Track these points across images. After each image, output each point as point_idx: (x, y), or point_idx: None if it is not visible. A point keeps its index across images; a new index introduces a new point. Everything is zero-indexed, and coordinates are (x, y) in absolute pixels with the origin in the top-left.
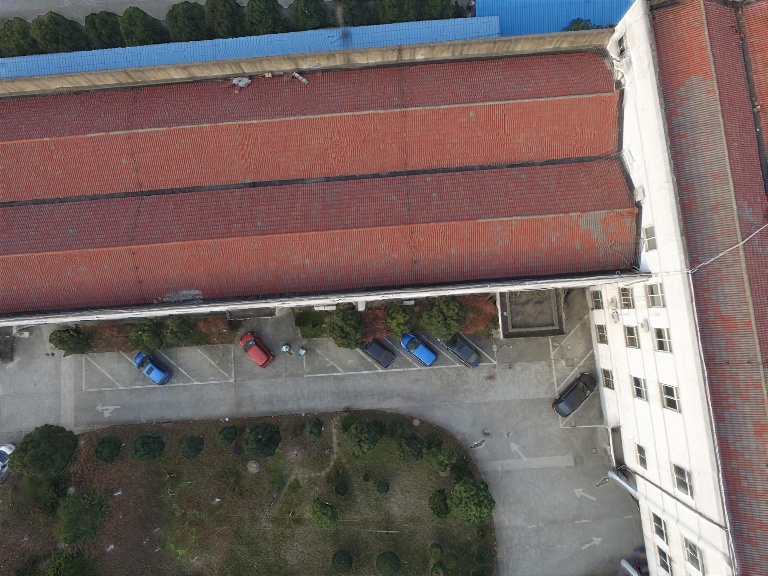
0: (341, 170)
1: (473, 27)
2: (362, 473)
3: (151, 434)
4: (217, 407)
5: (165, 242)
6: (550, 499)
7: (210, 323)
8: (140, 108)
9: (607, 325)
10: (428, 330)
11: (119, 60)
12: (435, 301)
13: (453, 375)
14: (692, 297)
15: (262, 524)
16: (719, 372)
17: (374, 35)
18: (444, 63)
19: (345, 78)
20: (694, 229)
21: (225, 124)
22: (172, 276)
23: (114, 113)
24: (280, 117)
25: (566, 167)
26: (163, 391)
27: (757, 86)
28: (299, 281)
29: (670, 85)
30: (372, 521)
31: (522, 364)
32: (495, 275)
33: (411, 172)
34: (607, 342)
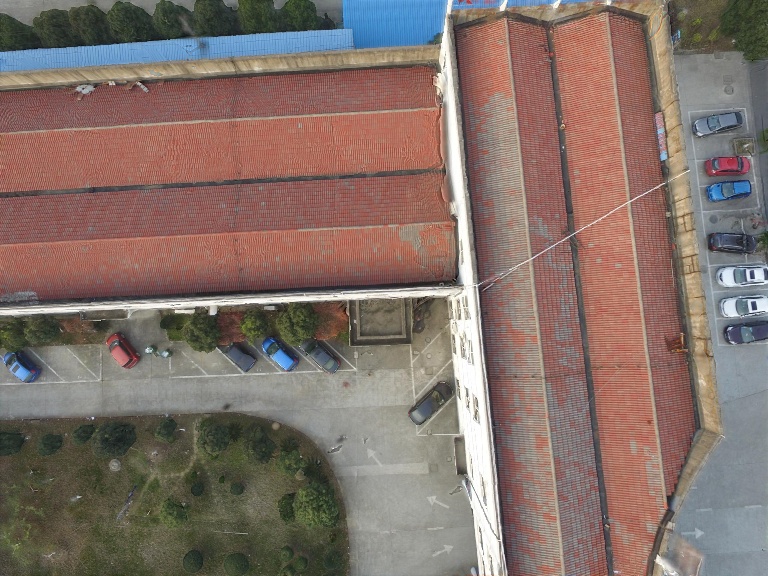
0: (187, 177)
1: (327, 39)
2: (220, 475)
3: (18, 431)
4: (83, 406)
5: None
6: (404, 506)
7: (74, 323)
8: None
9: (455, 335)
10: None
11: None
12: (288, 307)
13: (314, 380)
14: (478, 311)
15: (121, 522)
16: (508, 385)
17: (231, 45)
18: (282, 75)
19: (185, 88)
20: (492, 244)
21: (61, 130)
22: (7, 277)
23: None
24: None
25: (395, 179)
26: (32, 389)
27: (563, 105)
28: (130, 285)
29: (476, 102)
30: (227, 522)
31: (382, 371)
32: (321, 284)
33: (245, 181)
34: (455, 352)
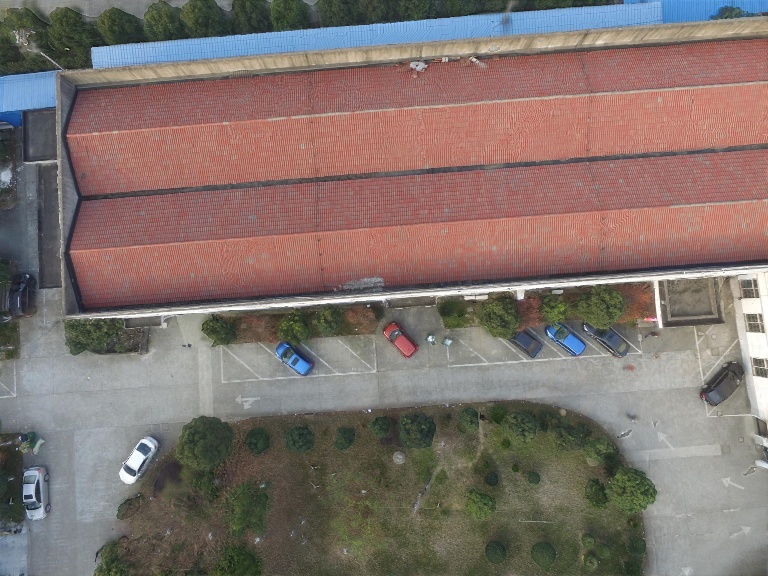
0: None
1: (635, 13)
2: (510, 464)
3: (293, 426)
4: (360, 398)
5: (352, 228)
6: (698, 488)
7: (358, 313)
8: (323, 92)
9: (764, 314)
10: (574, 320)
11: (274, 45)
12: (591, 290)
13: (599, 365)
14: None
15: (409, 516)
16: None
17: (535, 21)
18: (623, 48)
19: (524, 63)
20: None
21: (410, 109)
22: (355, 263)
23: (296, 97)
24: (452, 103)
25: (749, 153)
26: (304, 382)
27: None
28: (483, 268)
29: None
30: (521, 512)
31: (668, 353)
32: (681, 262)
33: (592, 158)
34: (764, 331)
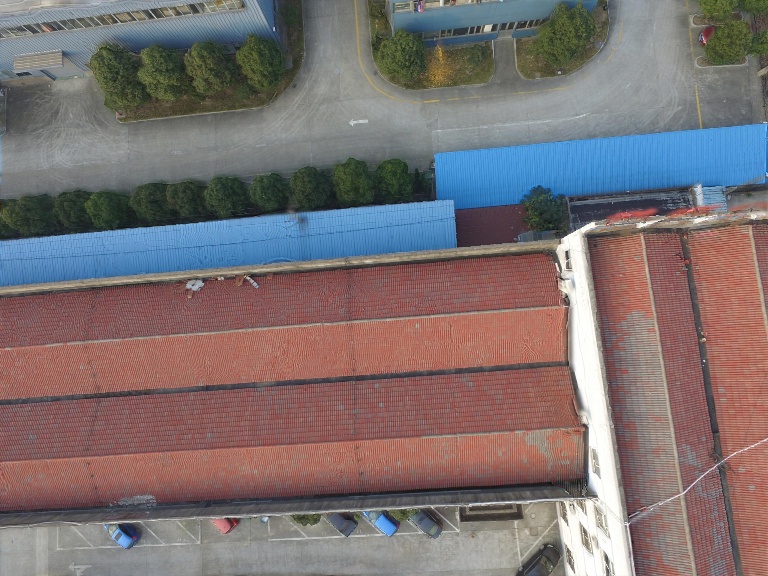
0: (294, 363)
1: (427, 211)
2: None
3: None
4: (184, 569)
5: (118, 454)
6: None
7: None
8: (95, 320)
9: (567, 507)
10: None
11: (85, 245)
12: None
13: (415, 542)
14: (630, 552)
15: None
16: None
17: (330, 220)
18: (393, 265)
19: (295, 282)
20: (636, 469)
21: (176, 336)
22: (126, 483)
23: (71, 325)
24: None
25: (514, 374)
26: (132, 552)
27: (703, 316)
28: (248, 489)
29: (611, 317)
30: None
31: (485, 533)
32: (442, 485)
33: (360, 376)
34: (568, 524)
